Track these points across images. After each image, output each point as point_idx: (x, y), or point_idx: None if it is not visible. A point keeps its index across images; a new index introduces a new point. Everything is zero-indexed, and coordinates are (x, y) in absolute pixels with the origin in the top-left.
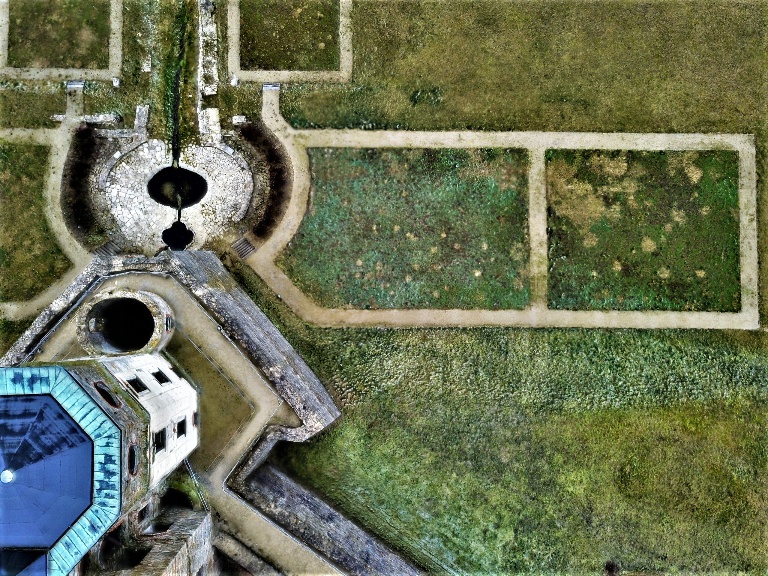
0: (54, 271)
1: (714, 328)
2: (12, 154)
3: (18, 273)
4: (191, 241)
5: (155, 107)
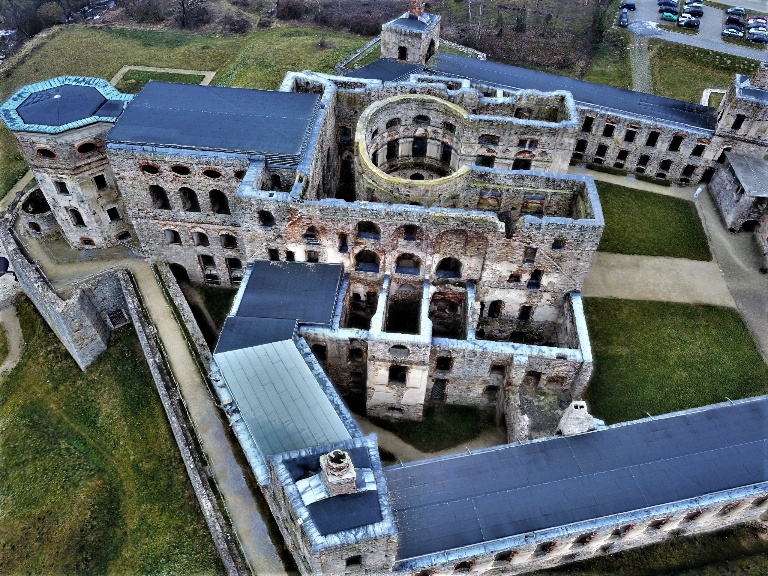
0: None
1: (209, 83)
2: None
3: None
4: None
5: None
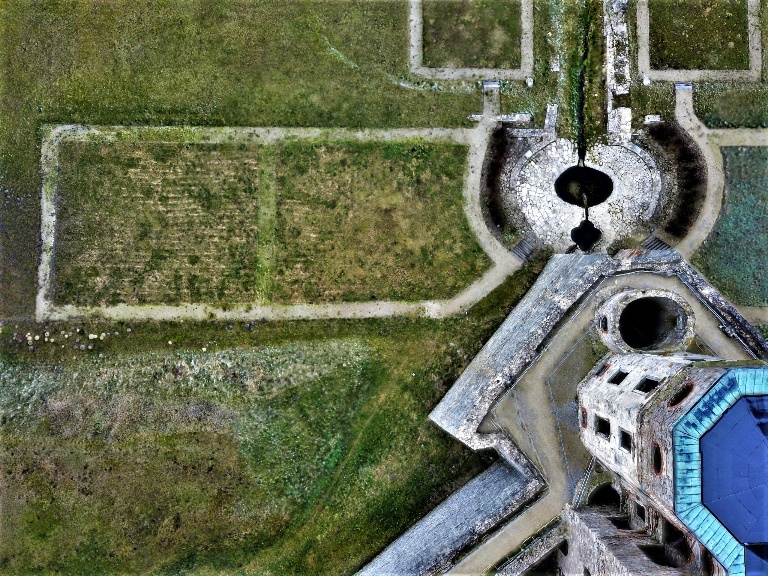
0: (476, 269)
1: None
2: (432, 154)
3: (441, 271)
4: (600, 239)
5: (561, 106)
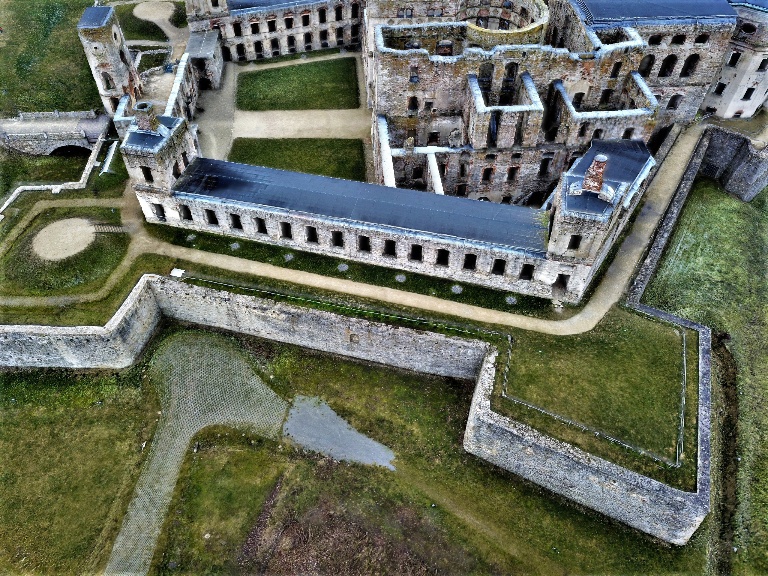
0: None
1: None
2: None
3: None
4: None
5: None
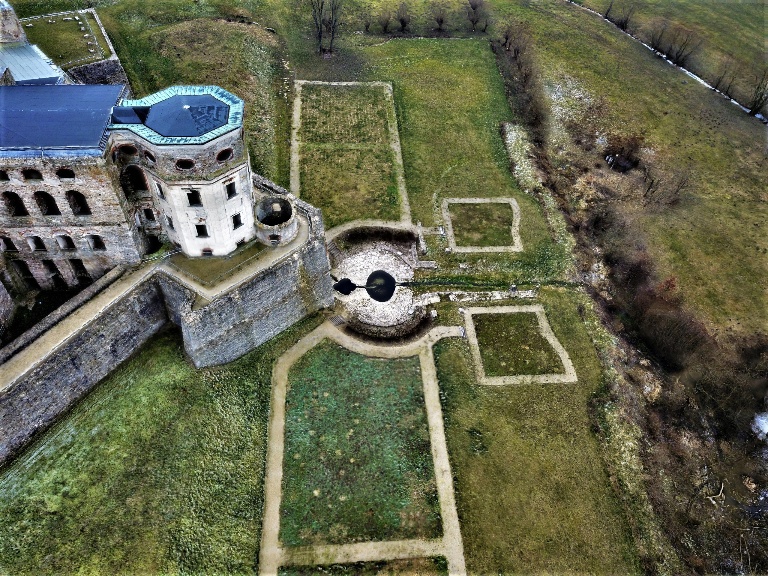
0: None
1: None
2: (393, 205)
3: None
4: (342, 293)
5: (436, 272)
